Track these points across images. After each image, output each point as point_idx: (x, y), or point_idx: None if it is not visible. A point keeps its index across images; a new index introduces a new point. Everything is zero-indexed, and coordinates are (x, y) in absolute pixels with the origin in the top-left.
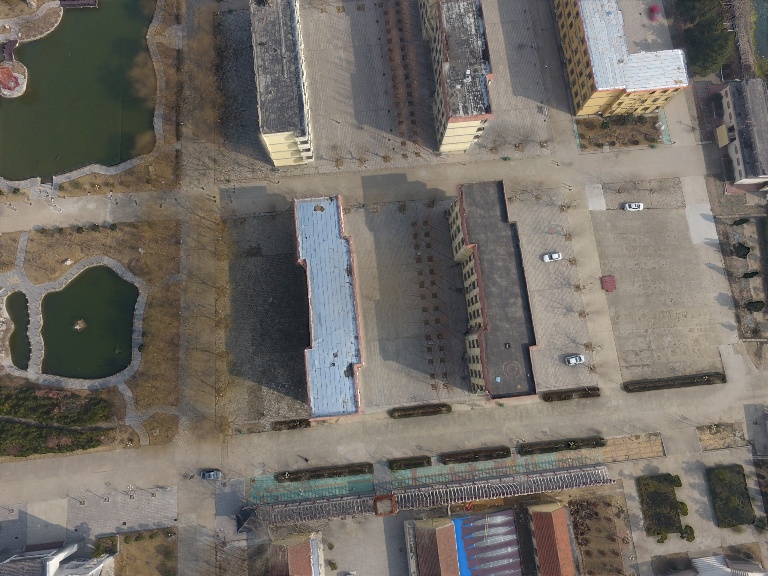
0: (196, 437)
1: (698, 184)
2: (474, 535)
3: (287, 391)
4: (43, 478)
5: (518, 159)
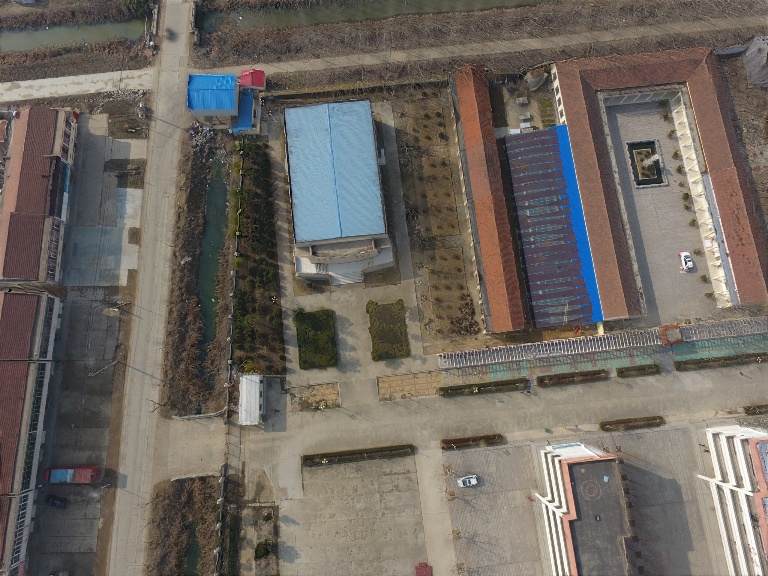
0: None
1: None
2: (579, 306)
3: None
4: None
5: None
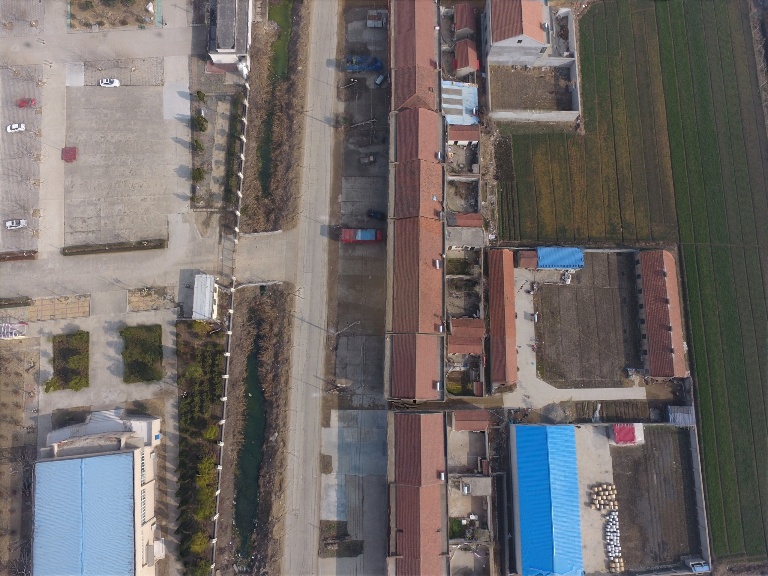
0: None
1: (181, 63)
2: None
3: None
4: None
5: (5, 37)
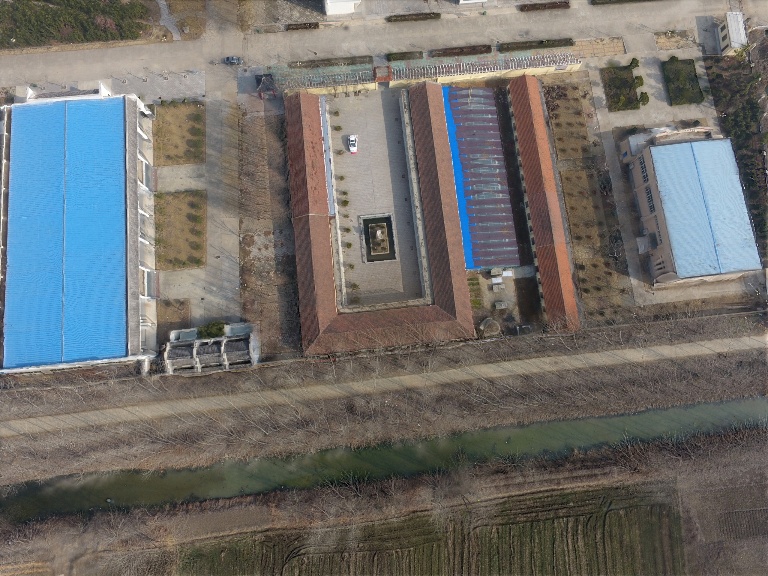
0: (221, 35)
1: None
2: (459, 101)
3: (299, 2)
4: (91, 63)
5: None
